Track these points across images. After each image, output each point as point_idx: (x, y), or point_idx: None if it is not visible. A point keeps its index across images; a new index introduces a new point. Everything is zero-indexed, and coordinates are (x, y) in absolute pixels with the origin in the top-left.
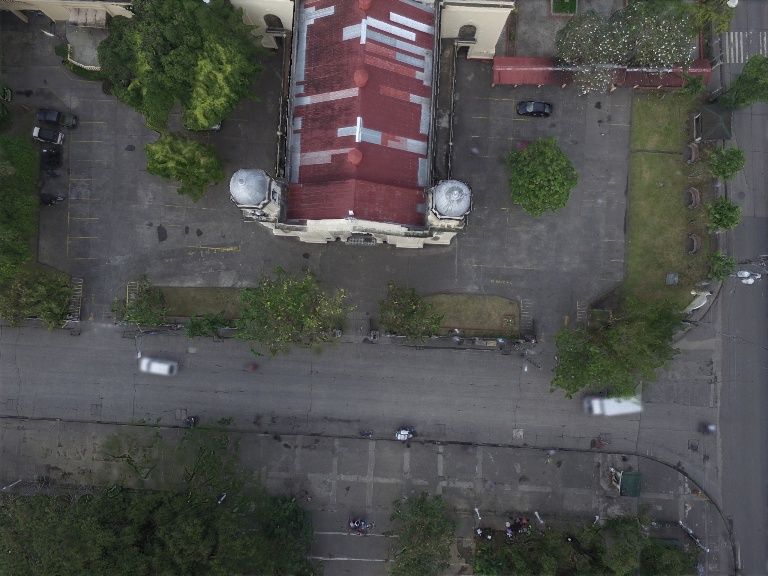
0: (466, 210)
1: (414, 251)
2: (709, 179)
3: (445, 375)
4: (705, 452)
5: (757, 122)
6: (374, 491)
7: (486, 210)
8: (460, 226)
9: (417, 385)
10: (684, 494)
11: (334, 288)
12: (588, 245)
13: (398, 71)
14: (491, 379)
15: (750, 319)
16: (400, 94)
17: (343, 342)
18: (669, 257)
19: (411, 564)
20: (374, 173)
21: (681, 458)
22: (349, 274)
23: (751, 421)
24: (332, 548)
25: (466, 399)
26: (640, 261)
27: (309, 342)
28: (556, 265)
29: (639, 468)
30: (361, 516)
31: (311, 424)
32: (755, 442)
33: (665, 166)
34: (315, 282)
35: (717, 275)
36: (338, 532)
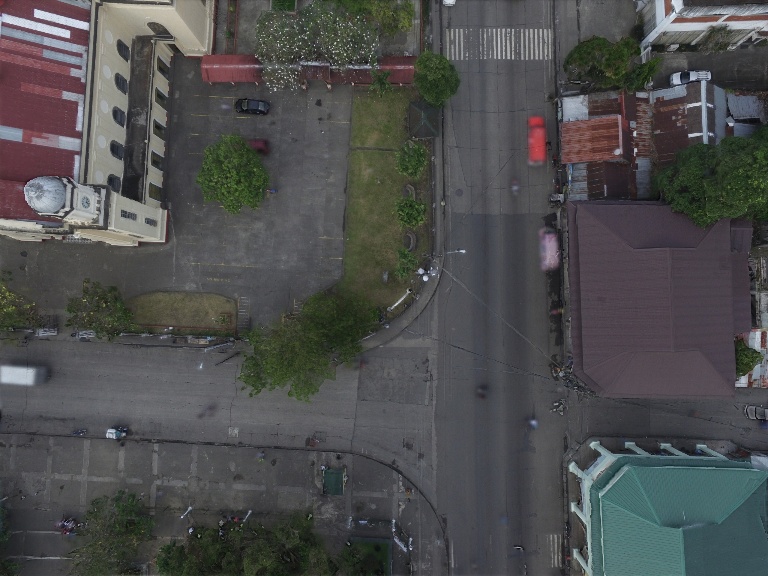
0: (60, 206)
1: (132, 249)
2: (428, 176)
3: (161, 373)
4: (420, 450)
5: (475, 119)
6: (88, 490)
7: (205, 208)
8: (95, 223)
9: (133, 383)
10: (398, 492)
11: (51, 286)
12: (306, 243)
13: (46, 68)
14: (207, 377)
15: (466, 317)
16: (49, 91)
17: (59, 340)
18: (388, 255)
19: (83, 563)
20: (12, 170)
21: (396, 456)
22: (67, 272)
23: (466, 419)
24: (45, 547)
25: (181, 397)
26: (358, 259)
27: (26, 340)
28: (274, 263)
29: (354, 466)
30: (74, 515)
31: (26, 423)
32: (470, 440)
33: (385, 163)
34: (2, 280)
35: (400, 272)
36: (50, 531)
